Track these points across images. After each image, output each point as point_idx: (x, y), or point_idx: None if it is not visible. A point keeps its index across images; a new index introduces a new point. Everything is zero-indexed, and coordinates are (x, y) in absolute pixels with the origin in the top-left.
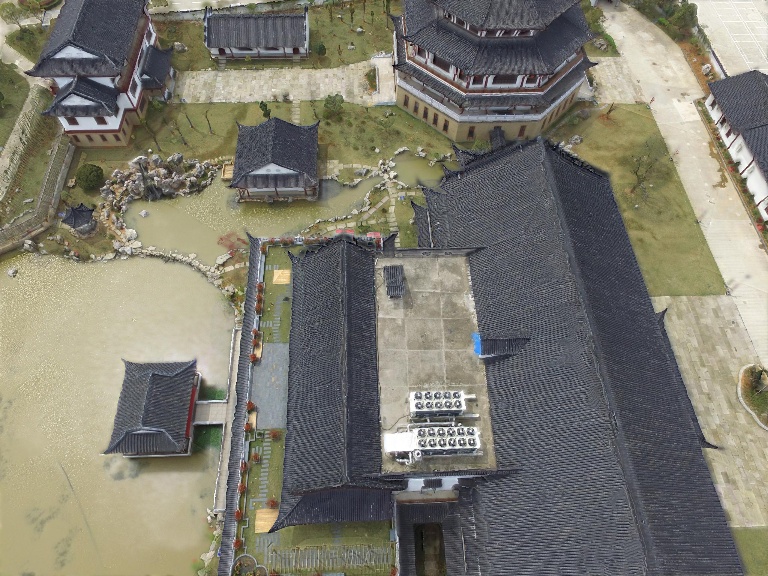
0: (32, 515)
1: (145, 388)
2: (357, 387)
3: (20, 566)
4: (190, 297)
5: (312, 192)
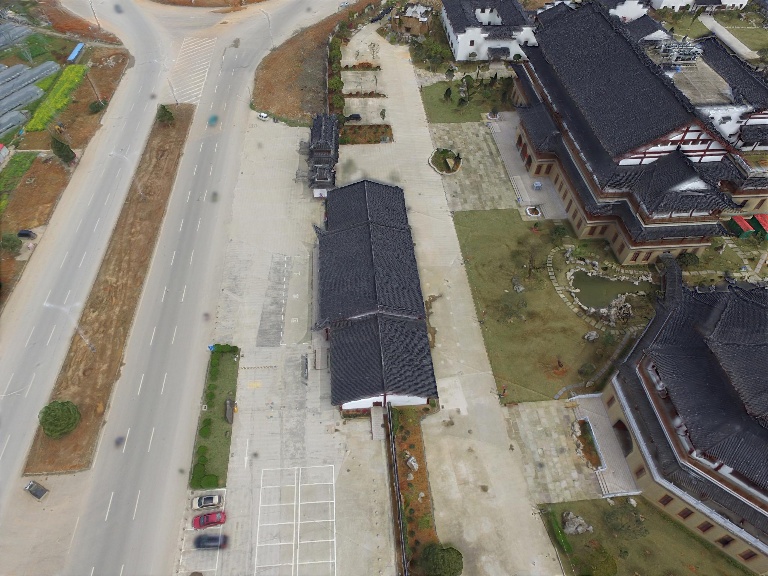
0: None
1: None
2: None
3: None
4: None
5: None
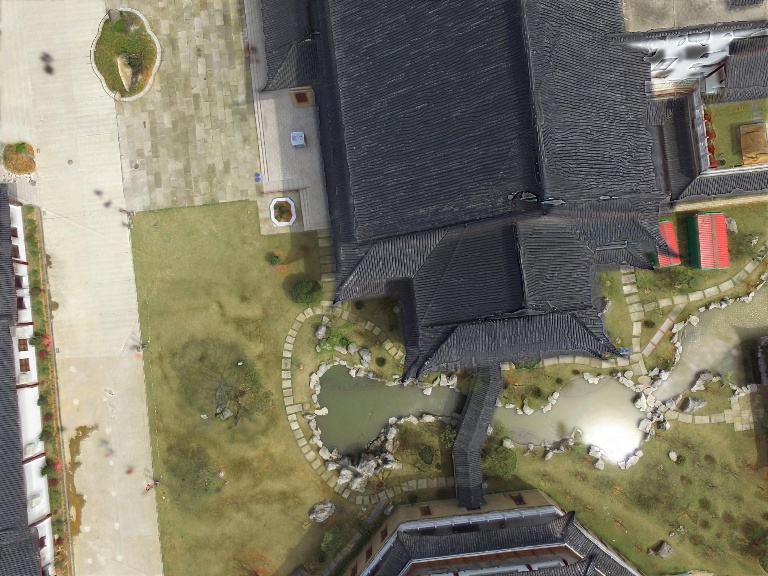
0: None
1: None
2: None
3: None
4: None
5: None
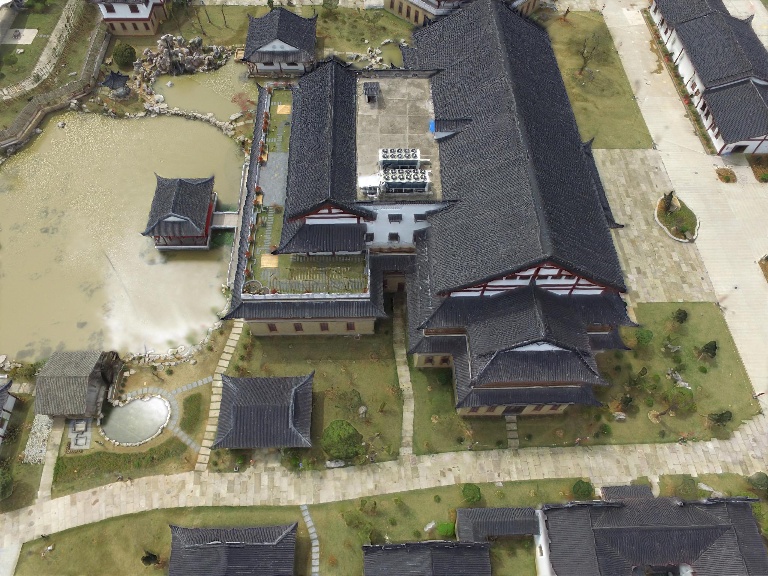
0: (83, 286)
1: (174, 190)
2: (340, 149)
3: (75, 318)
4: (208, 148)
5: (310, 69)
